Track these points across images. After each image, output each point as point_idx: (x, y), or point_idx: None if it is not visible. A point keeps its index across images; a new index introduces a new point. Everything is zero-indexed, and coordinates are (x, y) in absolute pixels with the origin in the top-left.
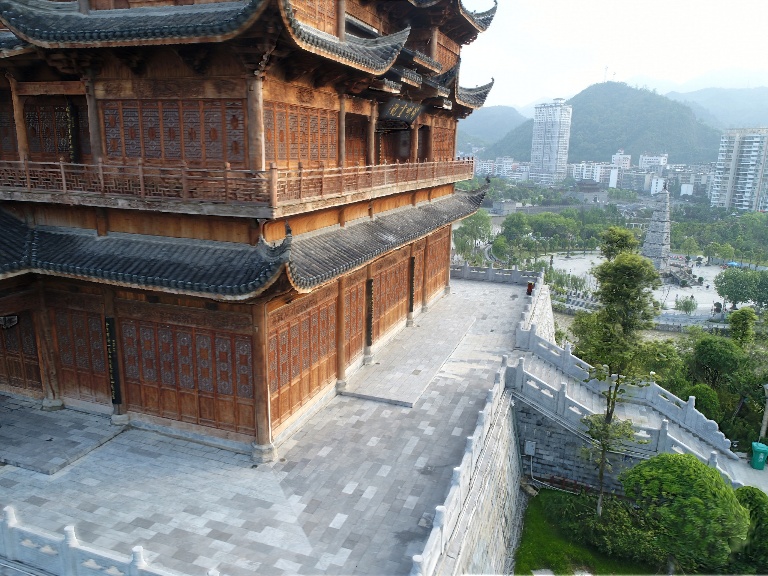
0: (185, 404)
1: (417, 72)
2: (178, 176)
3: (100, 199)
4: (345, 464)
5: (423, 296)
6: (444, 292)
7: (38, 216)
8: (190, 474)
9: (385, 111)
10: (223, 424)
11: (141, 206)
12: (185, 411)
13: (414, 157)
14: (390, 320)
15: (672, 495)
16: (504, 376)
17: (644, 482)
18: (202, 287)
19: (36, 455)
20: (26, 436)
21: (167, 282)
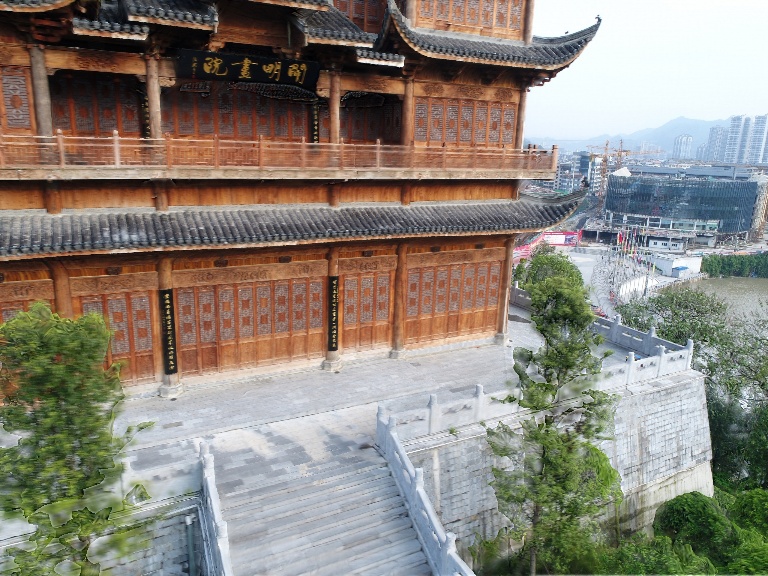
0: None
1: (282, 12)
2: None
3: None
4: None
5: (394, 336)
6: (493, 341)
7: None
8: None
9: (186, 68)
10: None
11: None
12: None
13: (330, 137)
14: (262, 352)
15: None
16: (191, 473)
17: None
18: None
19: None
20: None
21: None
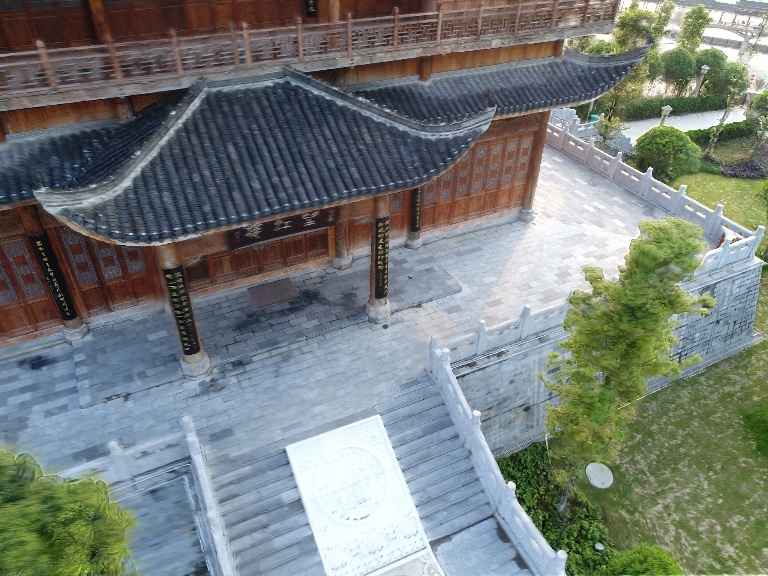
0: (472, 205)
1: None
2: (551, 8)
3: (475, 43)
4: (562, 200)
5: None
6: None
7: (349, 75)
8: (520, 245)
9: None
10: (500, 207)
11: (513, 42)
12: (471, 211)
13: None
14: None
15: (680, 147)
16: None
17: (662, 146)
18: (571, 99)
19: (431, 288)
20: (389, 286)
21: (544, 103)
